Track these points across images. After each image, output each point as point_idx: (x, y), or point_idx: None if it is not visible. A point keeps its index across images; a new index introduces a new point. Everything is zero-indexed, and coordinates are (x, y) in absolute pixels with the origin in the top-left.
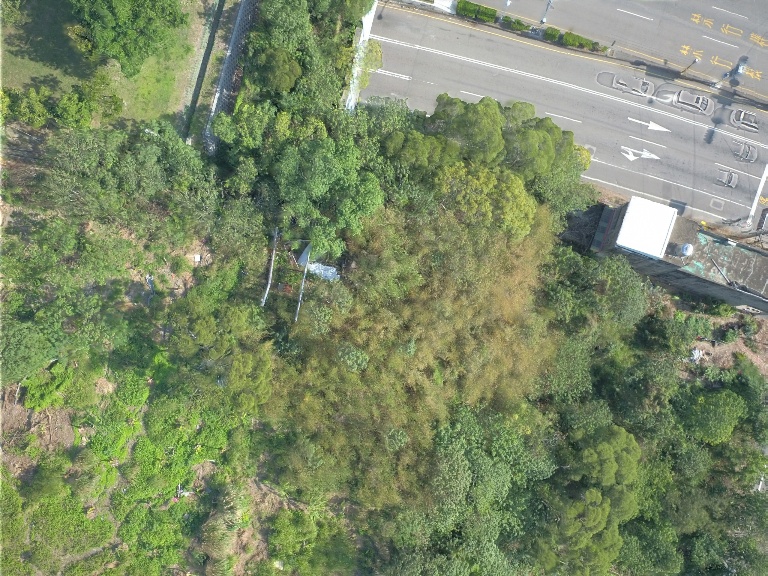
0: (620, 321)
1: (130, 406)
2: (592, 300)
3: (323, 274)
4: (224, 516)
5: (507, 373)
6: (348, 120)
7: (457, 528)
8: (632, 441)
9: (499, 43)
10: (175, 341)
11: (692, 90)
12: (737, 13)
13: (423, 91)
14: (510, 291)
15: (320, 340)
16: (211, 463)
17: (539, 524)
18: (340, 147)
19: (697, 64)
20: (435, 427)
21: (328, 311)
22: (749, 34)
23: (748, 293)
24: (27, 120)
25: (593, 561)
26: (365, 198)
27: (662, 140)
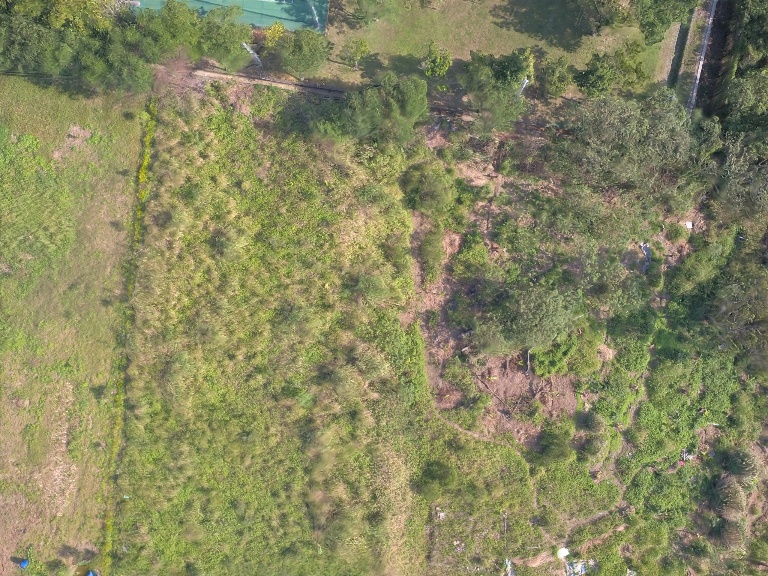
0: None
1: (632, 372)
2: None
3: None
4: (743, 478)
5: None
6: None
7: None
8: None
9: None
10: (675, 307)
11: None
12: None
13: None
14: None
15: None
16: (714, 427)
17: None
18: None
19: None
20: None
21: None
22: None
23: None
24: (555, 89)
25: None
26: None
27: None
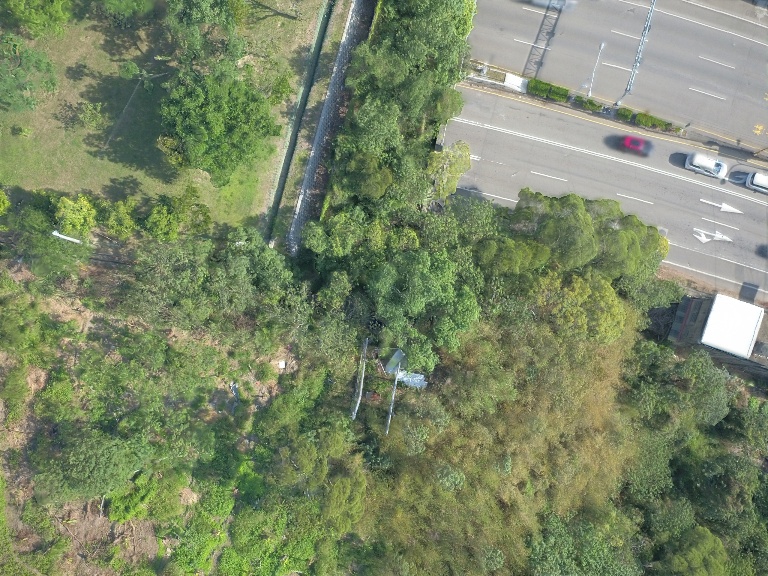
0: (704, 420)
1: (215, 517)
2: (675, 398)
3: (411, 382)
4: None
5: (593, 476)
6: (439, 228)
7: None
8: (720, 546)
9: (570, 122)
10: (261, 450)
11: (765, 171)
12: None
13: (493, 172)
14: (596, 393)
15: None
16: (298, 574)
17: None
18: (435, 261)
19: None
20: (529, 543)
21: (425, 430)
22: None
23: None
24: (114, 232)
25: None
26: (464, 317)
27: (735, 222)
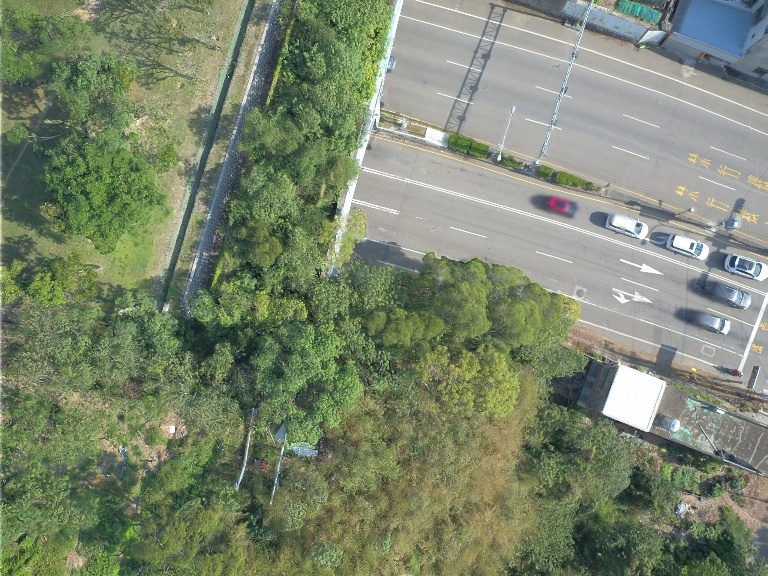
0: (604, 492)
1: None
2: (576, 468)
3: (300, 450)
4: None
5: (487, 547)
6: (329, 298)
7: None
8: None
9: (491, 178)
10: (147, 516)
11: (687, 232)
12: (735, 154)
13: (412, 226)
14: (492, 463)
15: None
16: None
17: None
18: (319, 335)
19: (693, 206)
20: None
21: (302, 507)
22: (747, 176)
23: (735, 464)
24: None
25: None
26: (343, 394)
27: (654, 283)
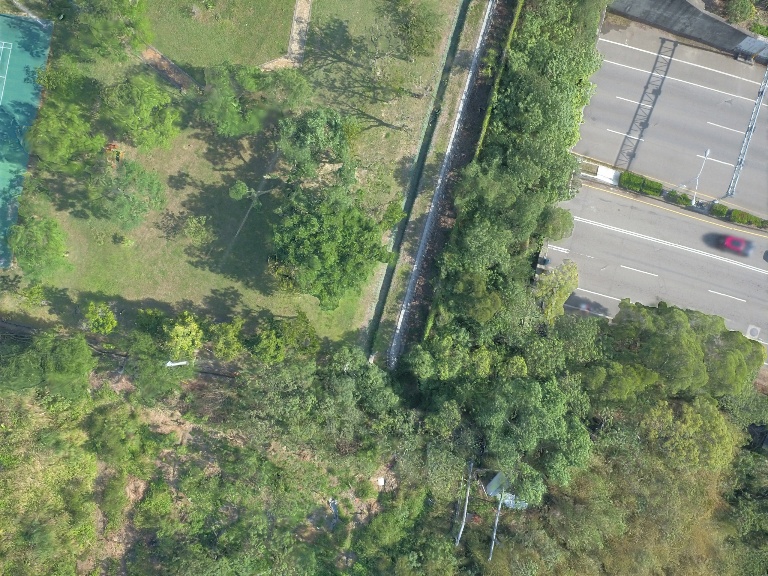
0: None
1: None
2: None
3: (512, 504)
4: None
5: None
6: (547, 353)
7: None
8: None
9: (662, 216)
10: (359, 569)
11: None
12: None
13: (582, 265)
14: None
15: None
16: None
17: None
18: (547, 392)
19: None
20: None
21: (534, 566)
22: None
23: None
24: (222, 355)
25: None
26: (578, 454)
27: None
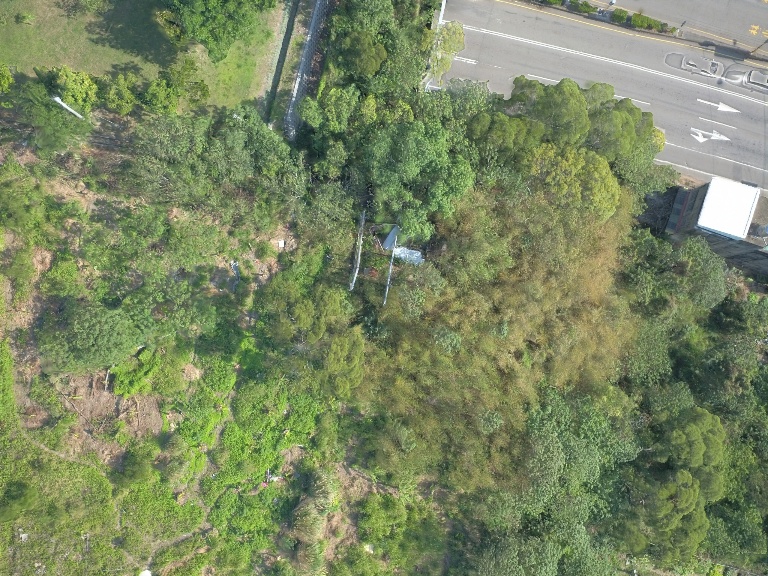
0: (702, 302)
1: (217, 392)
2: (672, 282)
3: (408, 258)
4: (315, 500)
5: (590, 356)
6: (434, 103)
7: (545, 510)
8: (718, 422)
9: (566, 25)
10: (261, 327)
11: (762, 70)
12: None
13: (490, 75)
14: (592, 273)
15: (409, 324)
16: (299, 448)
17: (622, 507)
18: (430, 129)
19: (767, 44)
20: (526, 409)
21: (421, 294)
22: None
23: None
24: (115, 107)
25: (684, 542)
26: (458, 180)
27: (732, 121)
